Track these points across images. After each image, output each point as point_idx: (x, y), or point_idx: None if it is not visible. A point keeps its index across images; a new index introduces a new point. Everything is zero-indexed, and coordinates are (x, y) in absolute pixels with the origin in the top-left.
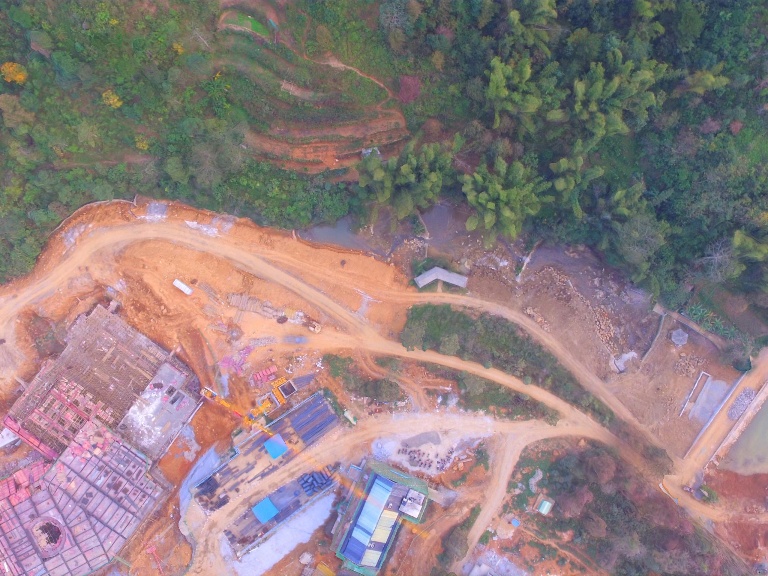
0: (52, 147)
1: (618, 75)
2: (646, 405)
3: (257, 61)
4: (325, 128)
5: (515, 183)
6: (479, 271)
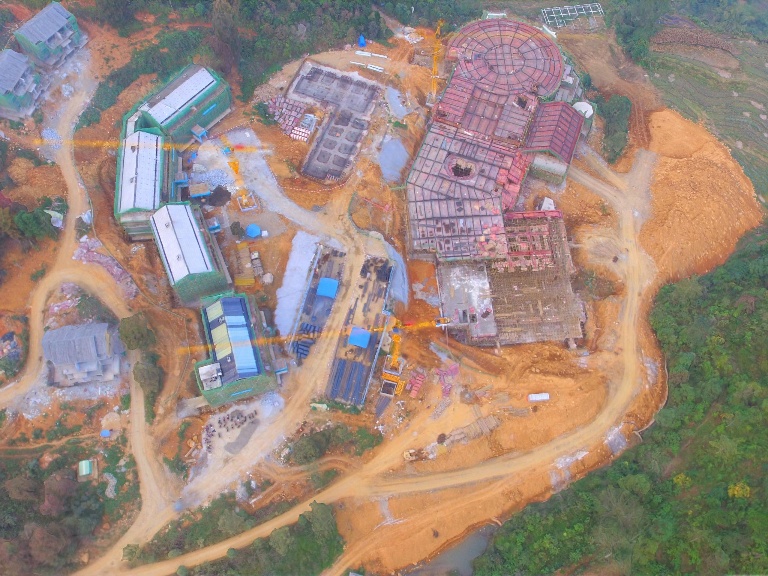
0: None
1: None
2: None
3: None
4: None
5: None
6: None
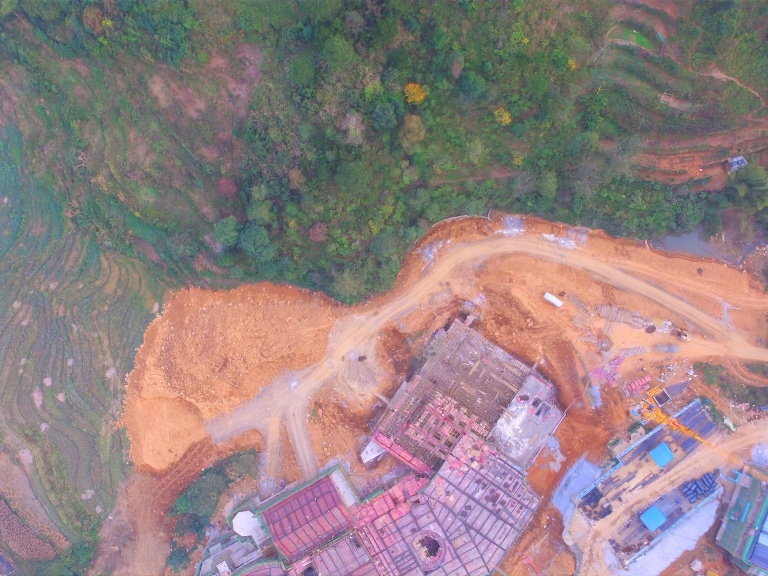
0: (428, 165)
1: None
2: None
3: (635, 74)
4: (696, 139)
5: None
6: None
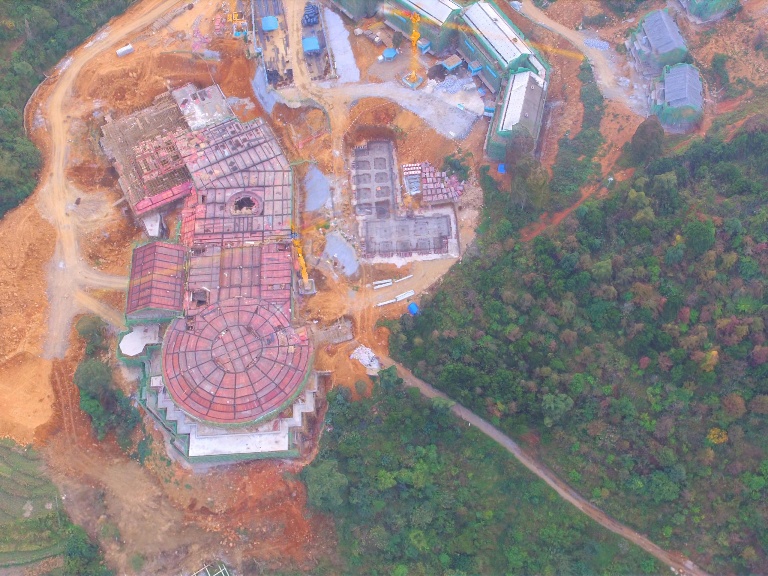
0: None
1: None
2: None
3: None
4: None
5: None
6: None
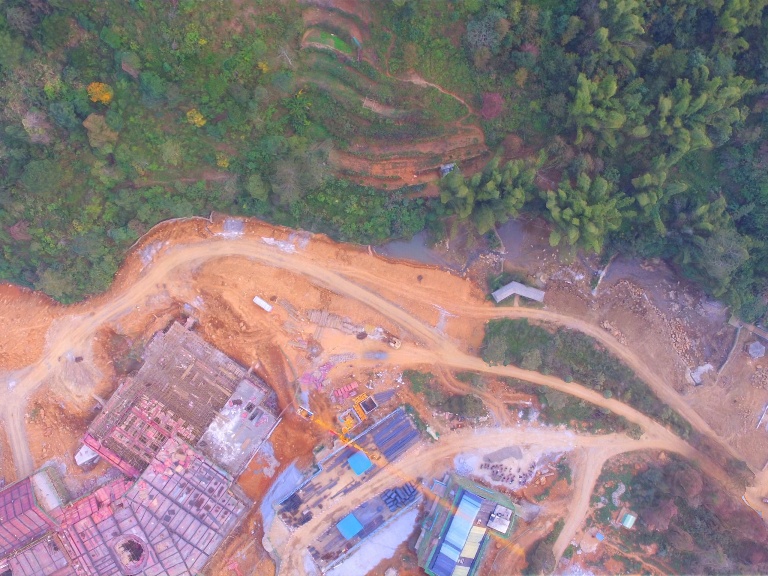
0: None
1: (705, 91)
2: (723, 417)
3: (338, 78)
4: (405, 144)
5: (598, 199)
6: (555, 285)
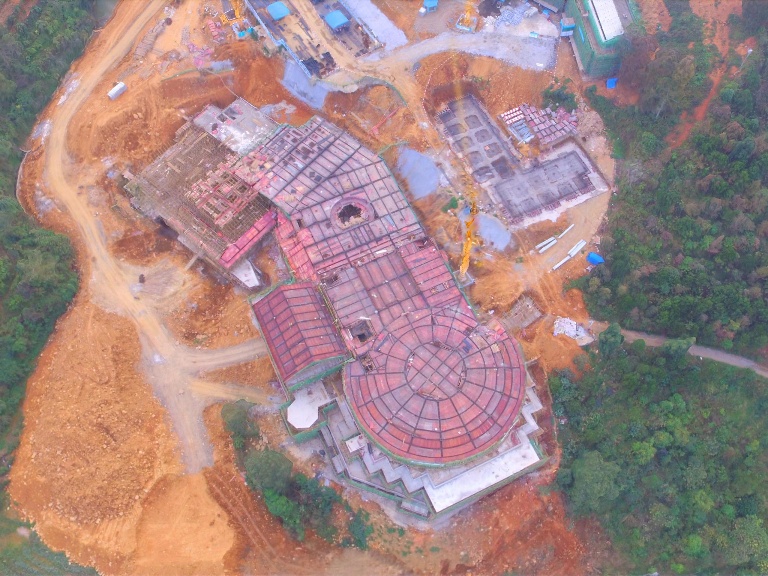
0: None
1: None
2: None
3: None
4: None
5: None
6: None
